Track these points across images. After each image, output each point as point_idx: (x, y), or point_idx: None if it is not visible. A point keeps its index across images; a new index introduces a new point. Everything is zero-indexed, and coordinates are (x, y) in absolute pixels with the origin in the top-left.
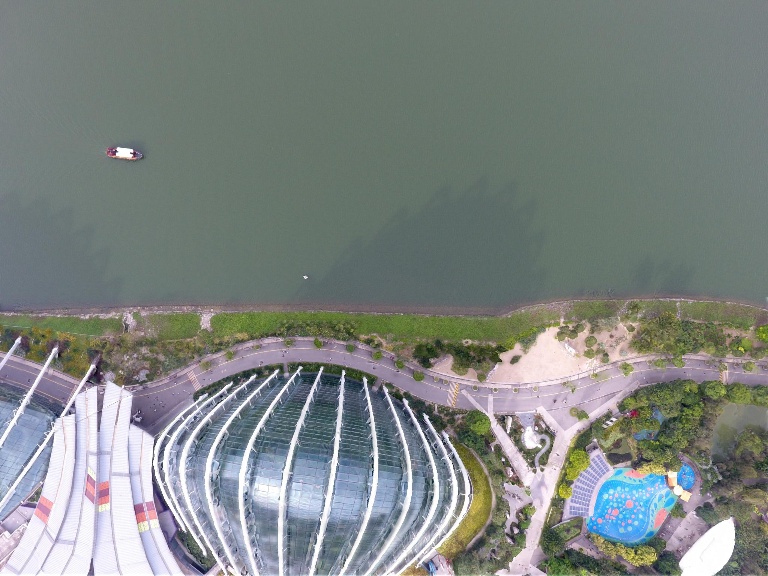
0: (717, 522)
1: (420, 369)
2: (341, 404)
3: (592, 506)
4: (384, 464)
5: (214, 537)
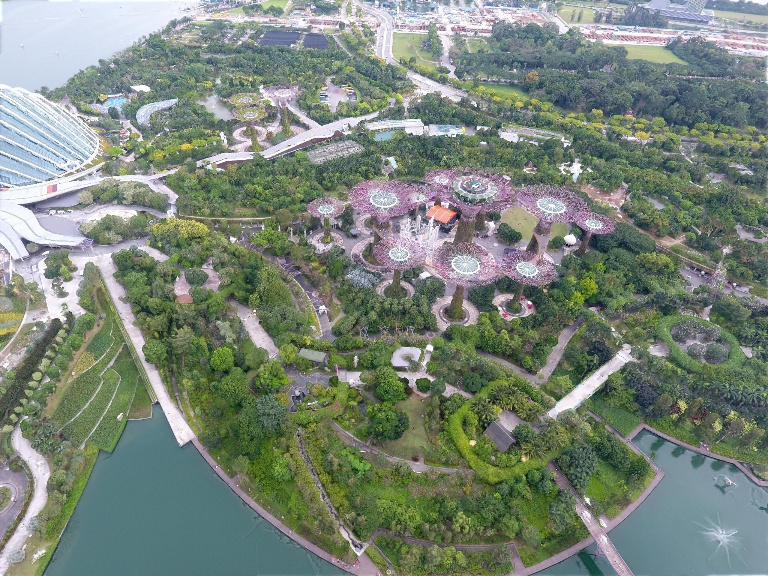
0: None
1: None
2: None
3: None
4: None
5: None
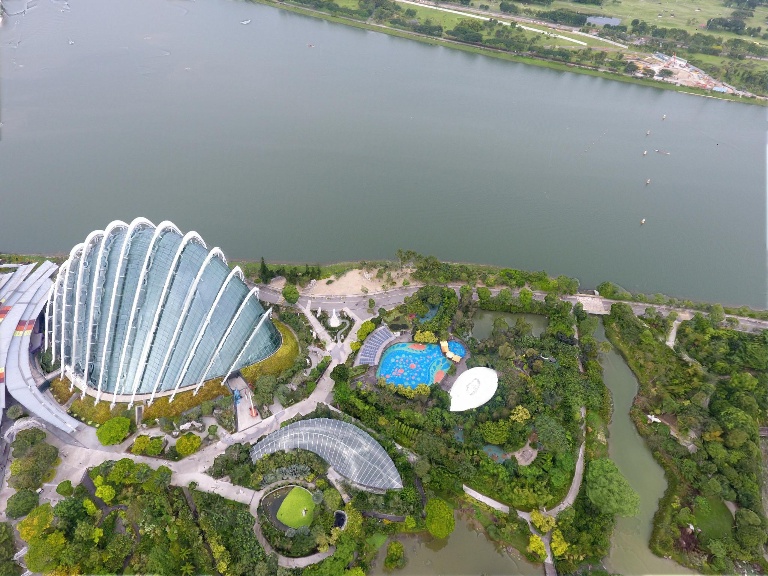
0: (478, 366)
1: (262, 285)
2: None
3: (377, 358)
4: None
5: (69, 328)
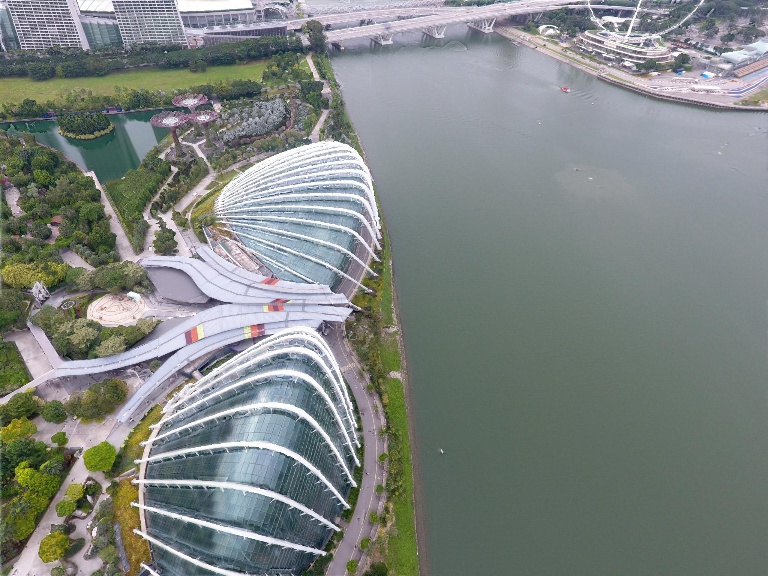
0: None
1: (358, 575)
2: (337, 452)
3: None
4: (287, 470)
5: None
